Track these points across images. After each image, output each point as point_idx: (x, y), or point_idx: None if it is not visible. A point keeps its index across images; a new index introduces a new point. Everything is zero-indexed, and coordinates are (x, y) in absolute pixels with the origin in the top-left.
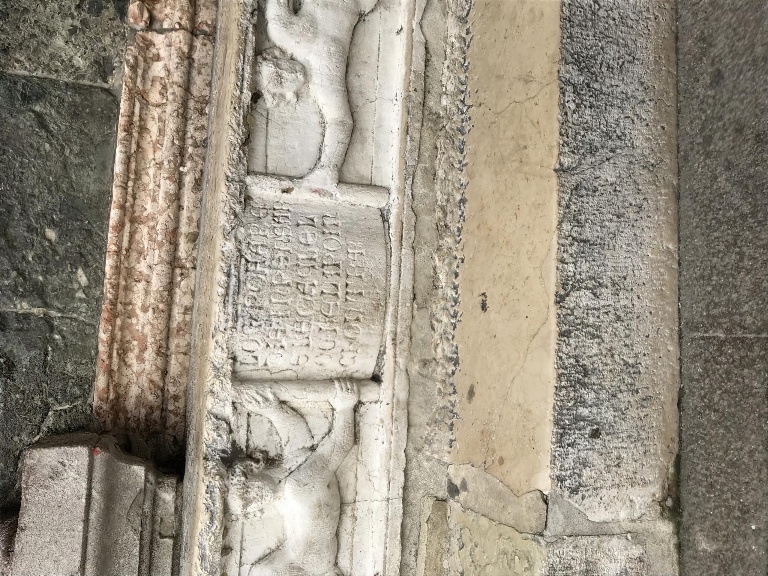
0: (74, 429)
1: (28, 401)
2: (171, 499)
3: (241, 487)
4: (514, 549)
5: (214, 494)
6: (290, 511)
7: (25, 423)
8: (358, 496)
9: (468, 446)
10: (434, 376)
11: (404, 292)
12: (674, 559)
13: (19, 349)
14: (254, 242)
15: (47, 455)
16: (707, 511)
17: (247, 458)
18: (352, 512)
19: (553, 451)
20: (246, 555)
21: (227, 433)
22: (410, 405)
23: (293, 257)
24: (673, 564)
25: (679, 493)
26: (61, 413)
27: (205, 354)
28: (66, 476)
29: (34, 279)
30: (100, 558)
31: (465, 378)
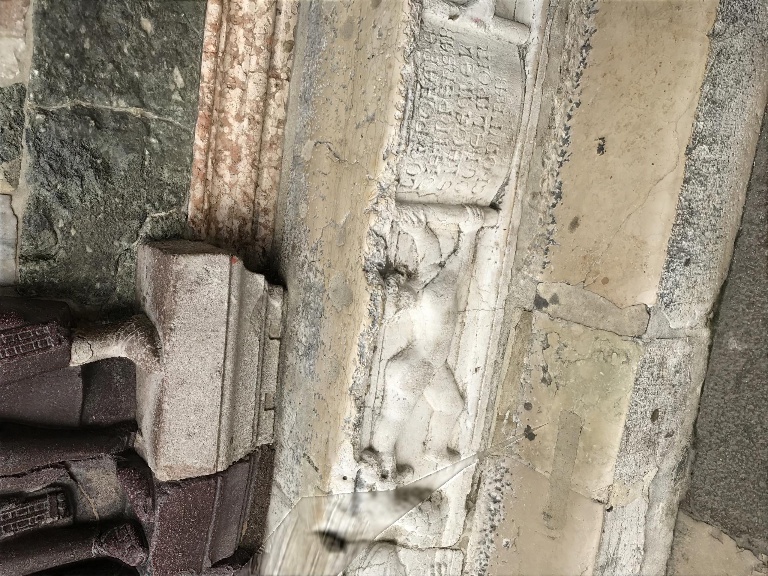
0: (170, 236)
1: (127, 206)
2: (279, 305)
3: (396, 296)
4: (613, 348)
5: (377, 301)
6: (423, 317)
7: (125, 228)
8: (468, 306)
9: (565, 268)
10: (538, 207)
11: (530, 130)
12: (706, 356)
13: (116, 150)
14: (427, 68)
15: (193, 261)
16: (744, 322)
17: (395, 271)
18: (462, 319)
19: (663, 275)
20: (384, 352)
21: (384, 248)
22: (519, 231)
23: (456, 87)
24: (705, 359)
25: (720, 309)
26: (158, 220)
27: (367, 174)
28: (210, 281)
29: (129, 74)
30: (236, 355)
31: (568, 211)
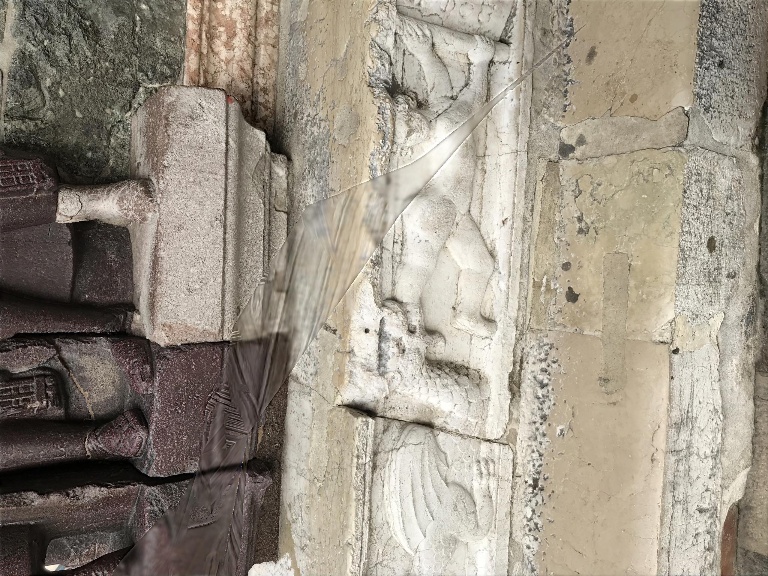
0: None
1: (118, 72)
2: (284, 174)
3: (406, 114)
4: (652, 164)
5: (385, 115)
6: None
7: (117, 95)
8: (488, 150)
9: (588, 102)
10: (551, 46)
11: None
12: (758, 187)
13: (105, 13)
14: None
15: (185, 93)
16: None
17: (403, 94)
18: (482, 165)
19: (696, 70)
20: None
21: (389, 64)
22: None
23: None
24: (758, 191)
25: (765, 133)
26: (152, 91)
27: None
28: (205, 117)
29: None
30: (237, 208)
31: (583, 44)
